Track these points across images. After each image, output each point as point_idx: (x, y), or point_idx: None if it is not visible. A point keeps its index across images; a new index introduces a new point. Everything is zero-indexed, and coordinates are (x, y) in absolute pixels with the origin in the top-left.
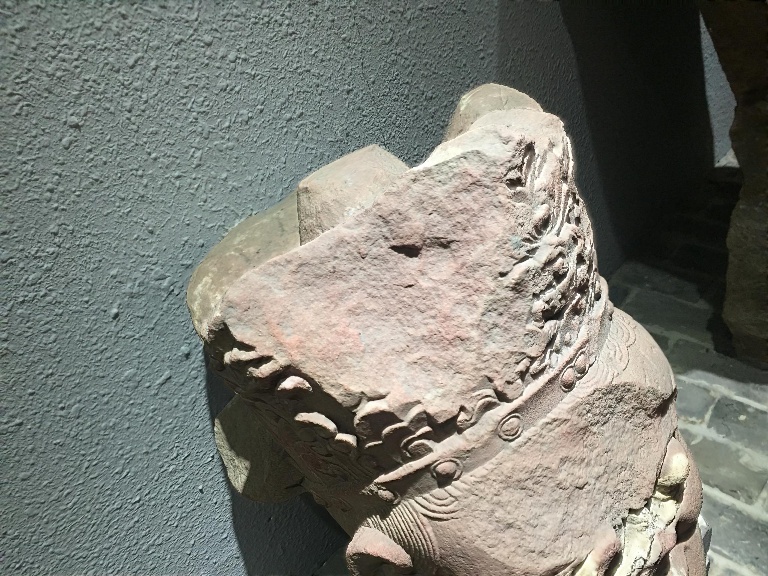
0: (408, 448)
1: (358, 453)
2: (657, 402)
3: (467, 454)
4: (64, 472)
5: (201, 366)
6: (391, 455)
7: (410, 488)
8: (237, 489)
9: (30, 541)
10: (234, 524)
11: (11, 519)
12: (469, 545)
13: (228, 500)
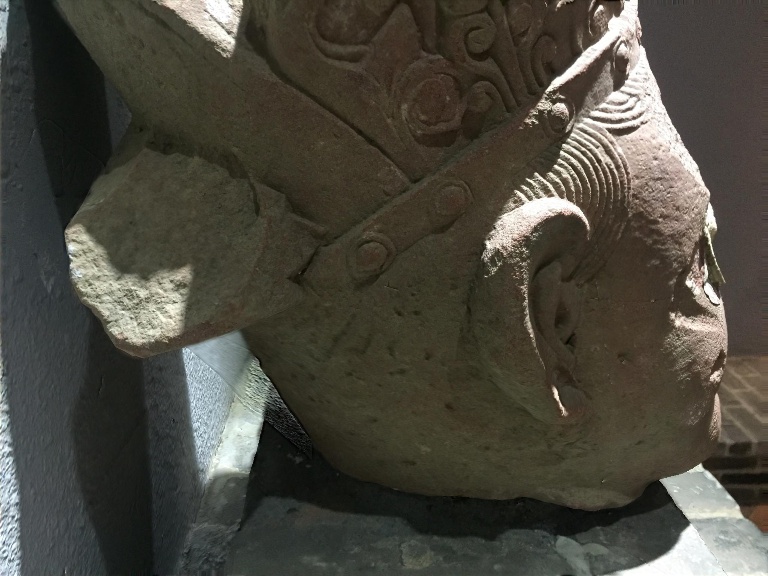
0: (593, 16)
1: (542, 26)
2: None
3: (631, 40)
4: None
5: None
6: (576, 29)
7: (588, 94)
8: (161, 337)
9: None
10: (21, 572)
11: None
12: (667, 155)
13: (14, 506)
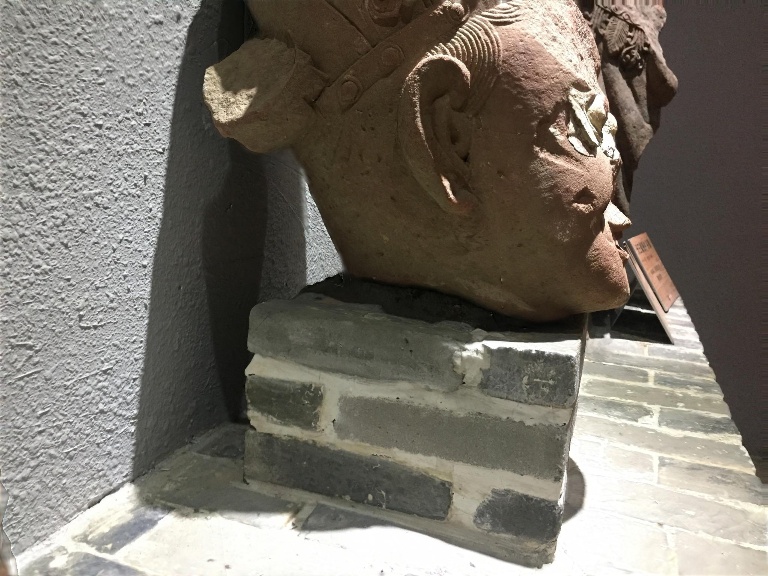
0: None
1: None
2: (598, 62)
3: None
4: (61, 15)
5: (183, 42)
6: None
7: (480, 1)
8: (234, 118)
9: (5, 57)
10: (155, 257)
11: (2, 9)
12: (531, 40)
13: (159, 219)
